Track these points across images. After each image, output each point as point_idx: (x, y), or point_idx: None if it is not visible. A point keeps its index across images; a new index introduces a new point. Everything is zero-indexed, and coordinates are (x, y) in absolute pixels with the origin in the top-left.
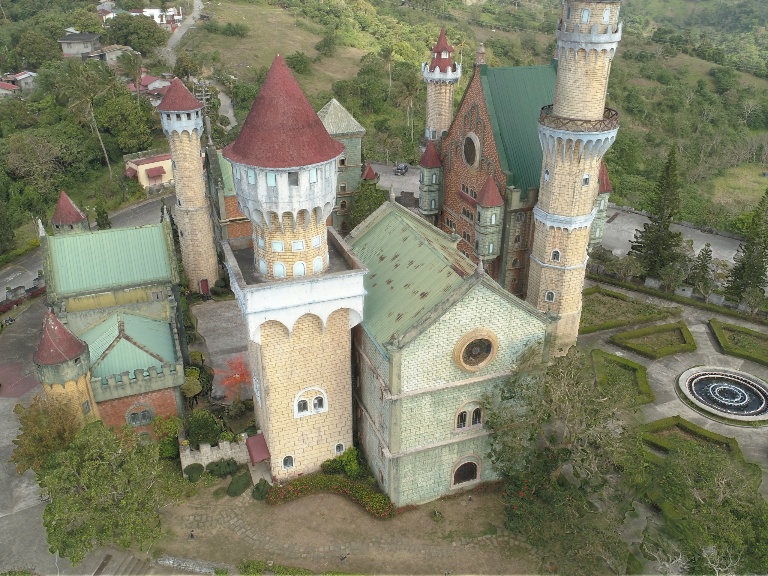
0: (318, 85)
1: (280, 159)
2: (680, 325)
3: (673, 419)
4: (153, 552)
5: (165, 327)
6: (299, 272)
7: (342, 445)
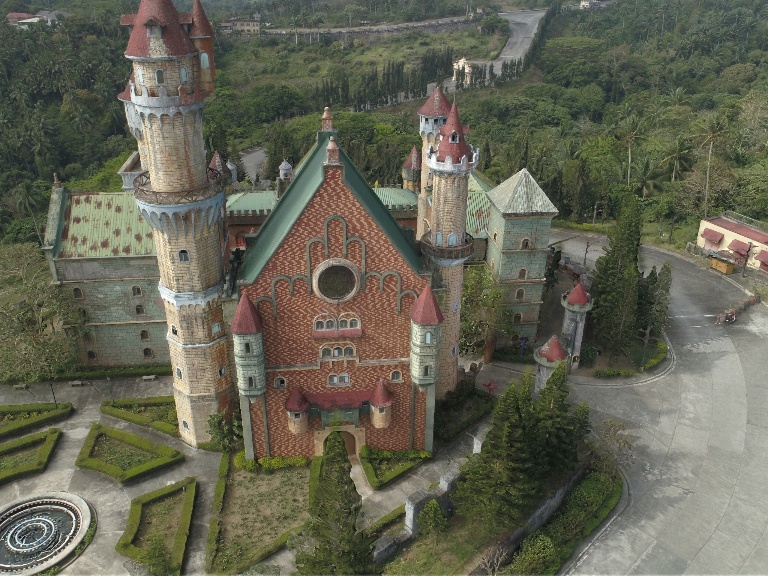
0: None
1: None
2: (172, 561)
3: (41, 459)
4: None
5: None
6: None
7: None
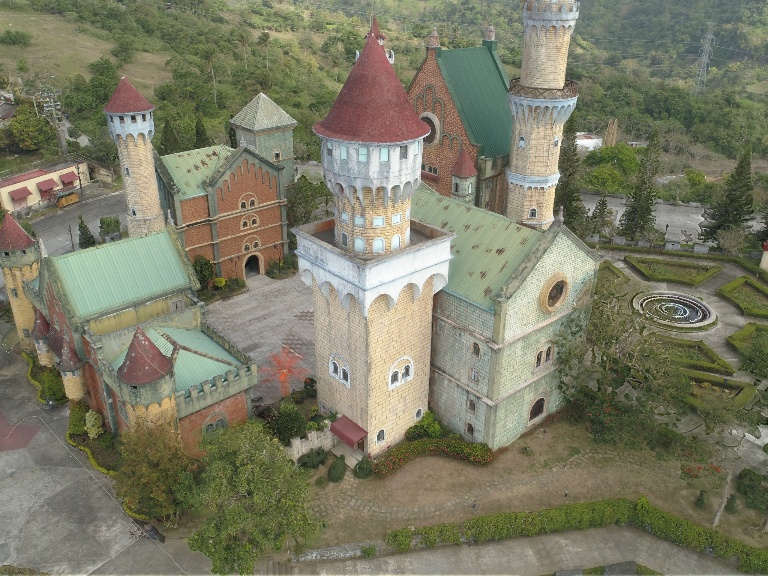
0: None
1: (393, 134)
2: (607, 264)
3: None
4: (294, 550)
5: (201, 335)
6: (395, 245)
7: (420, 410)
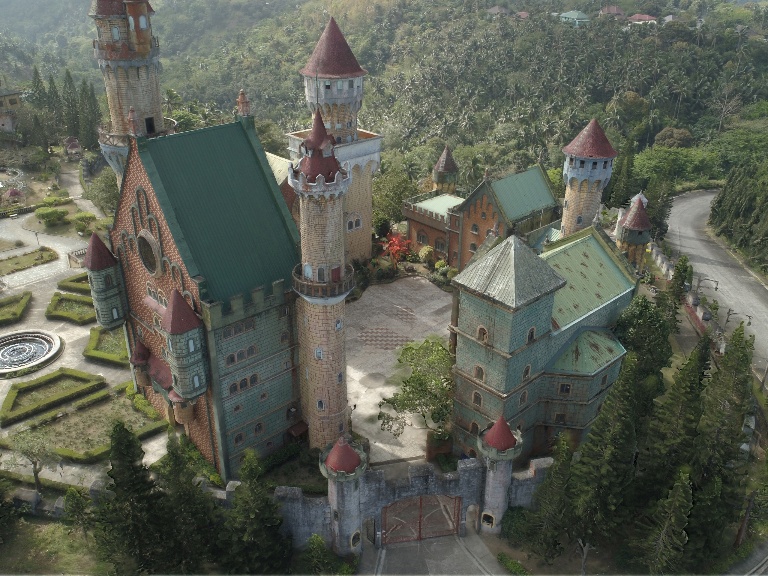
0: None
1: None
2: (8, 413)
3: (86, 316)
4: None
5: None
6: None
7: None
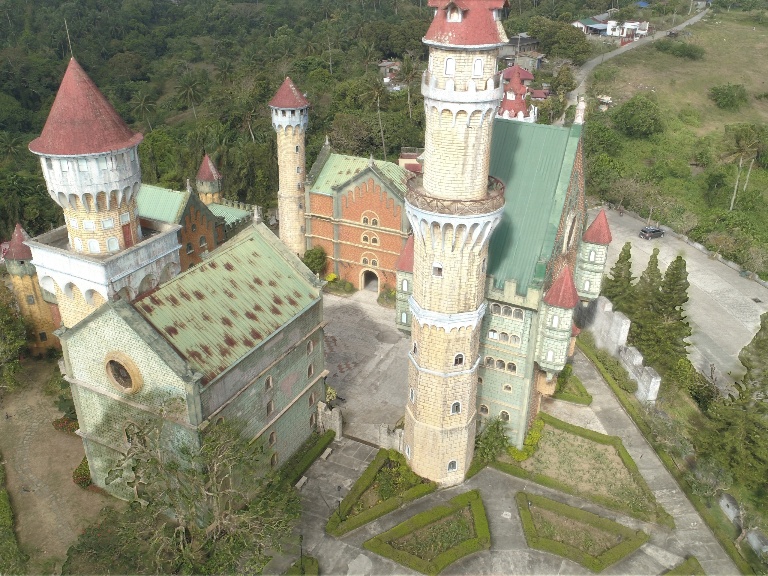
0: (727, 124)
1: (43, 144)
2: (633, 536)
3: None
4: None
5: None
6: (79, 247)
7: None
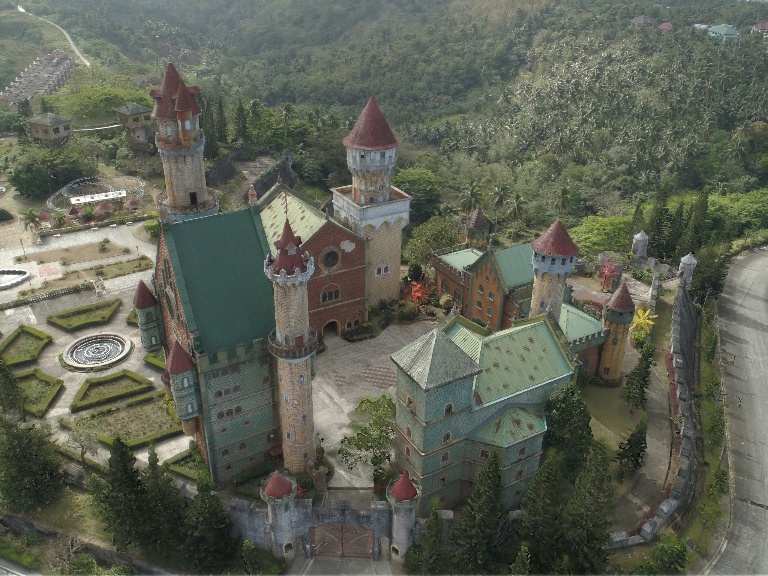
0: None
1: None
2: (78, 402)
3: None
4: None
5: None
6: None
7: None
